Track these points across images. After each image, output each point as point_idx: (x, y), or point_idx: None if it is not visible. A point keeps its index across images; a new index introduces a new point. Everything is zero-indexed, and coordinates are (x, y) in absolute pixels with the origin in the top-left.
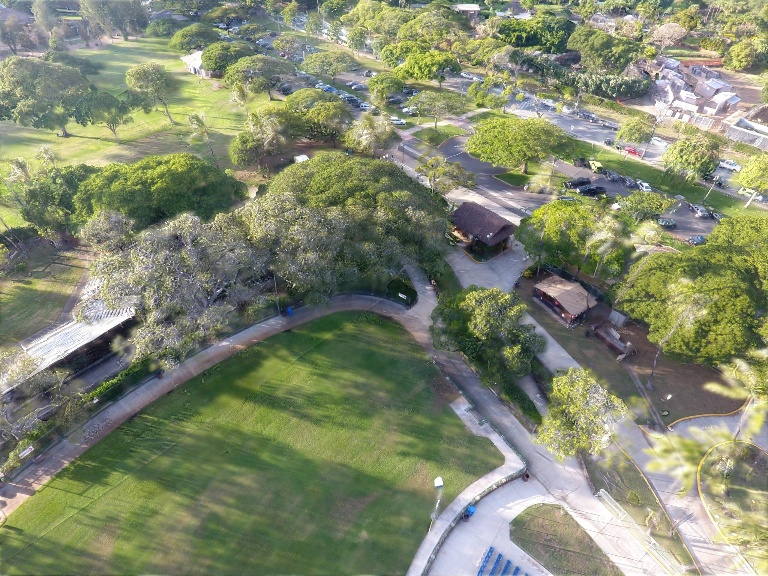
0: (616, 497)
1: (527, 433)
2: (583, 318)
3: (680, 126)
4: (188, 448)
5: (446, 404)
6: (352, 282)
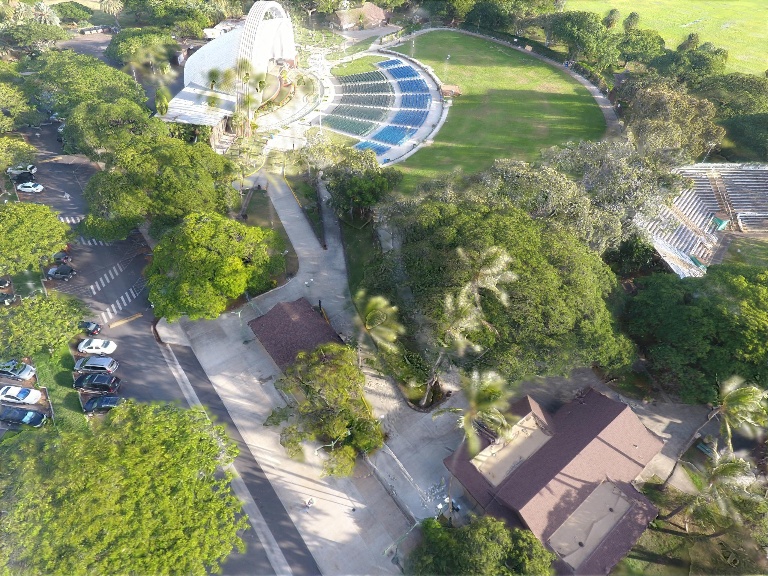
0: None
1: None
2: None
3: None
4: None
5: None
6: None
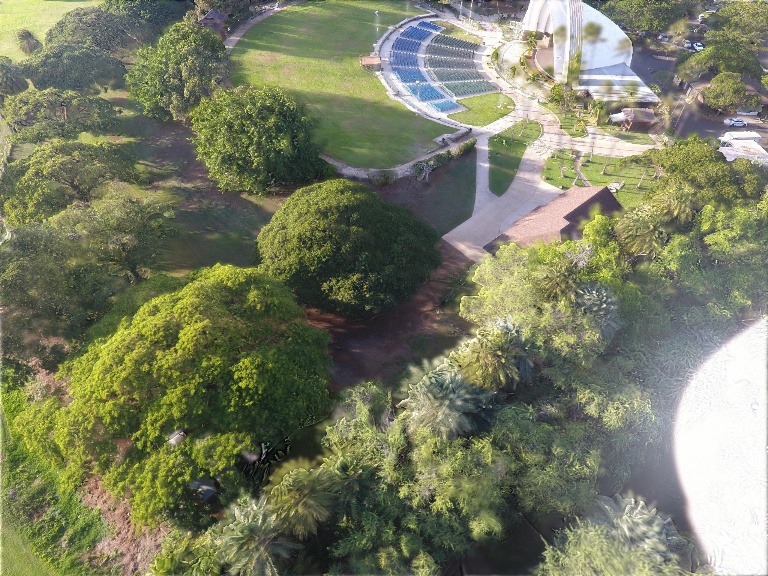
0: None
1: (439, 12)
2: None
3: None
4: None
5: (412, 5)
6: None
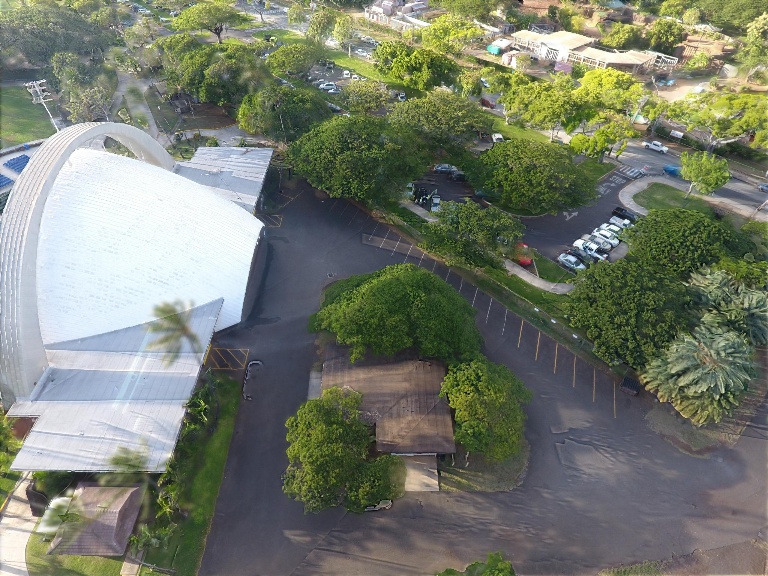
0: (113, 148)
1: None
2: (173, 97)
3: (360, 20)
4: None
5: (48, 118)
6: (25, 72)
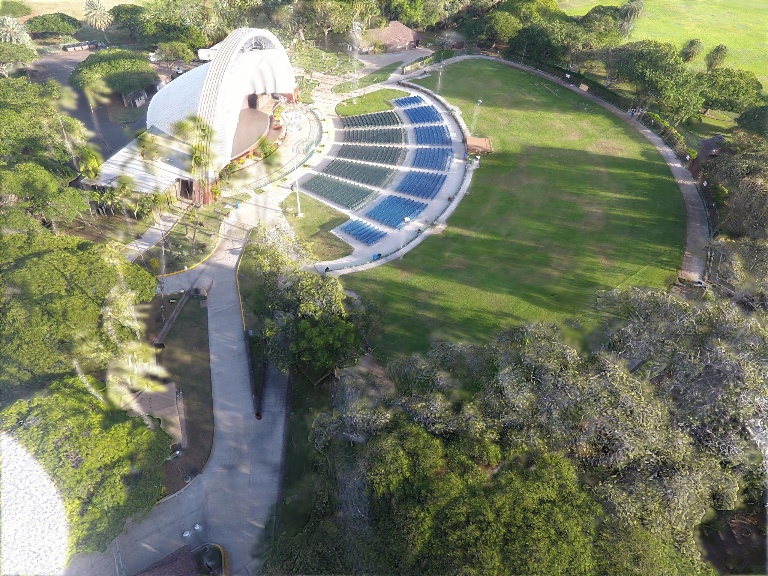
0: None
1: None
2: None
3: None
4: (584, 299)
5: None
6: None
